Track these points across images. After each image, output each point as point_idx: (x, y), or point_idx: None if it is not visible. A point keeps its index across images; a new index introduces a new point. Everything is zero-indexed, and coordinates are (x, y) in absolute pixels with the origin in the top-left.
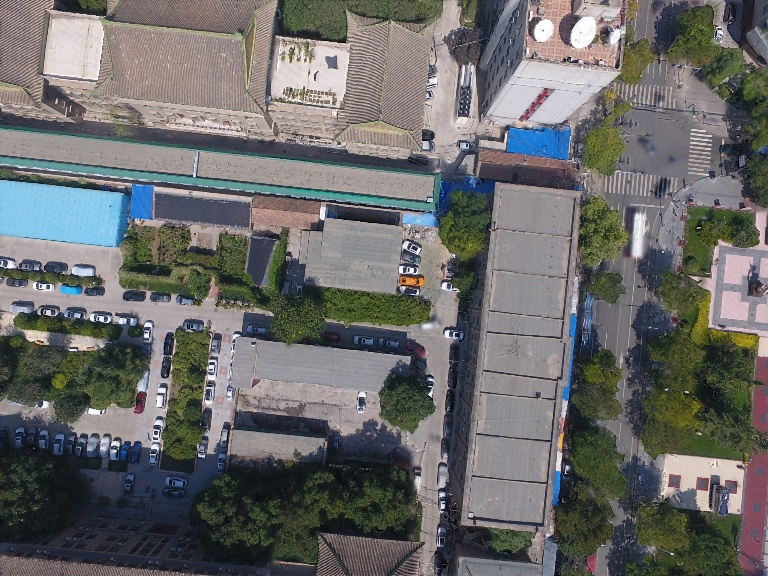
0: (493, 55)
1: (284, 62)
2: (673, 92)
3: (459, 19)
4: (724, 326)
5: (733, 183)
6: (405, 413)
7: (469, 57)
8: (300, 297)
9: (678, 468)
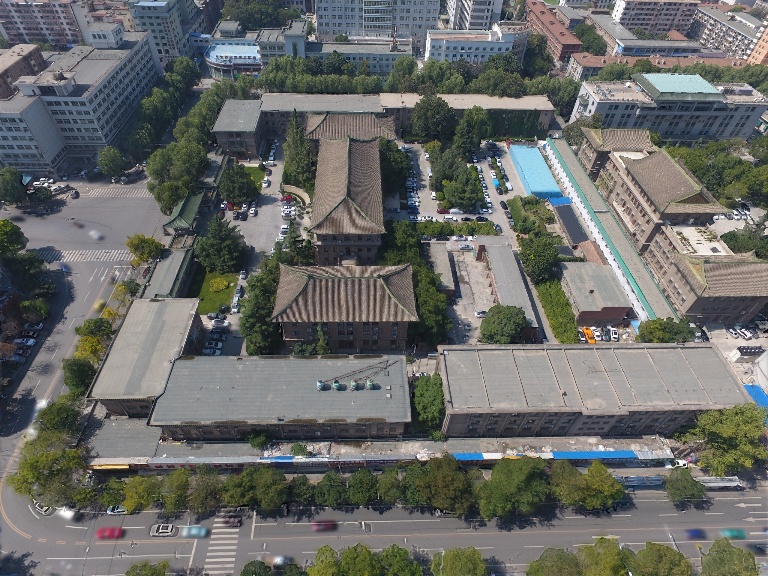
0: None
1: (695, 230)
2: None
3: None
4: None
5: None
6: None
7: None
8: None
9: None
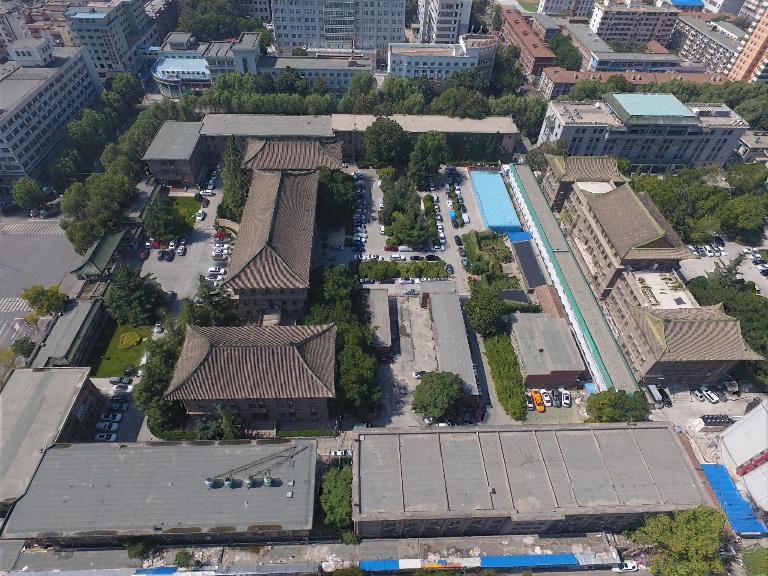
0: None
1: (659, 276)
2: None
3: None
4: None
5: None
6: None
7: None
8: None
9: None
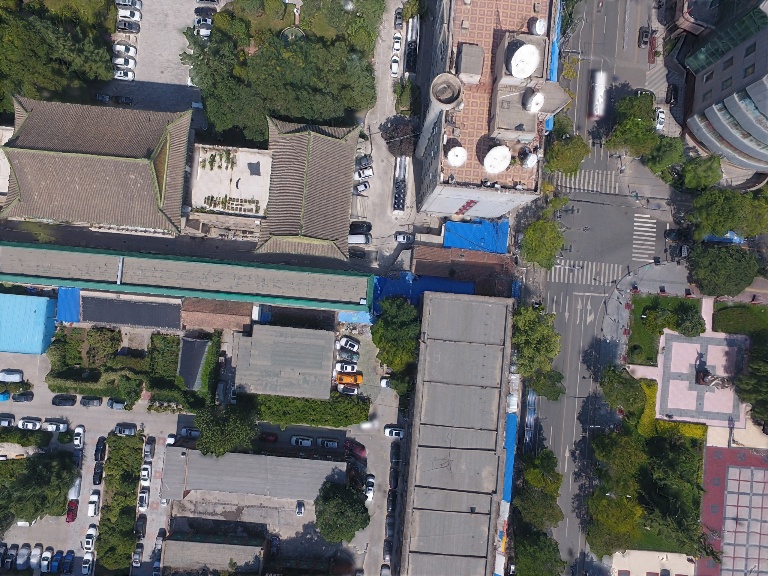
0: (425, 151)
1: (205, 170)
2: (616, 176)
3: (395, 106)
4: (672, 416)
5: (678, 269)
6: (336, 531)
7: (402, 151)
8: (227, 411)
9: (627, 563)
